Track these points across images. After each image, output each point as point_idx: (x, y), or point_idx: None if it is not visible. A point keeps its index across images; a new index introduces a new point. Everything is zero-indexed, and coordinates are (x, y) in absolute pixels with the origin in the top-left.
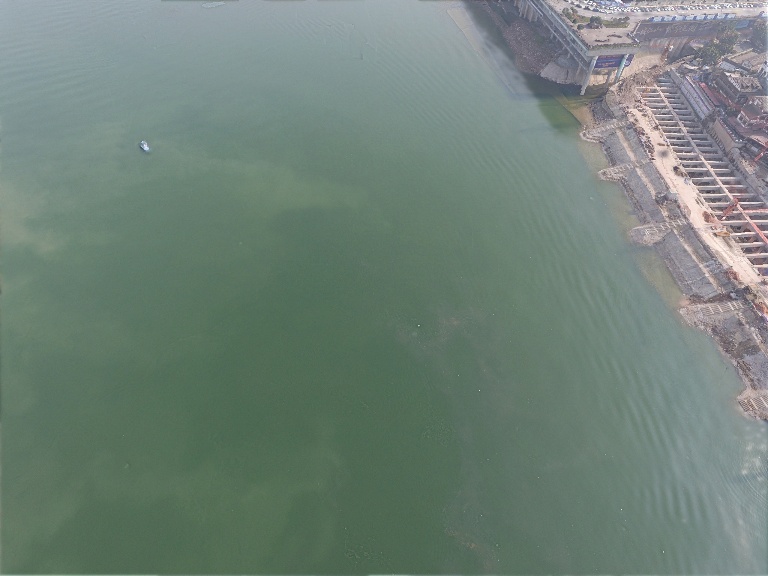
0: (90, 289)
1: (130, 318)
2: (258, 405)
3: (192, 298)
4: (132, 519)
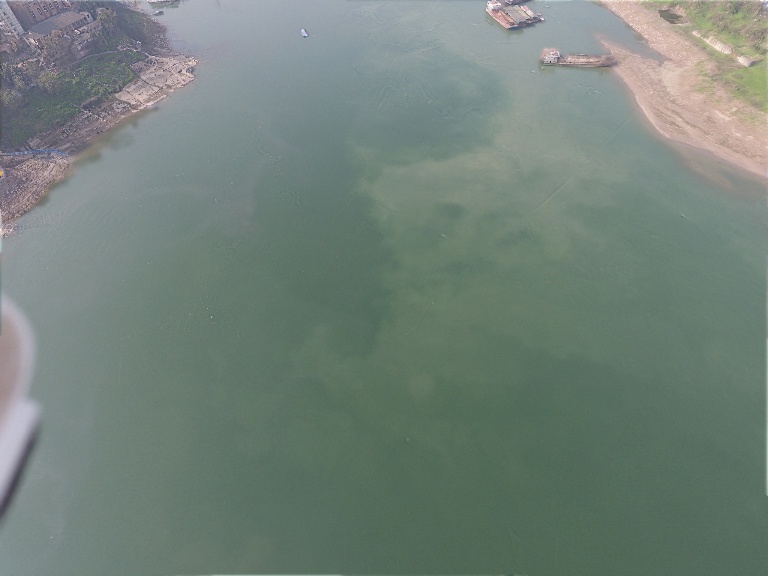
0: (564, 373)
1: (499, 338)
2: (356, 256)
3: (443, 355)
4: (428, 215)
